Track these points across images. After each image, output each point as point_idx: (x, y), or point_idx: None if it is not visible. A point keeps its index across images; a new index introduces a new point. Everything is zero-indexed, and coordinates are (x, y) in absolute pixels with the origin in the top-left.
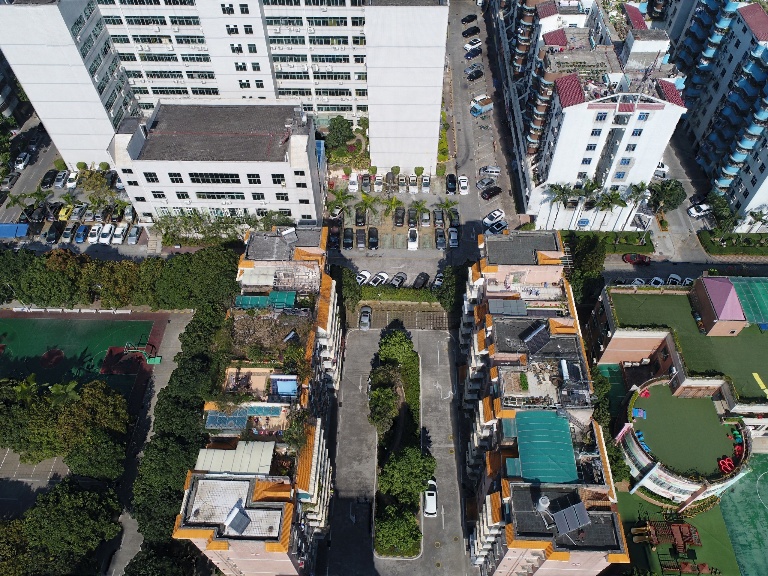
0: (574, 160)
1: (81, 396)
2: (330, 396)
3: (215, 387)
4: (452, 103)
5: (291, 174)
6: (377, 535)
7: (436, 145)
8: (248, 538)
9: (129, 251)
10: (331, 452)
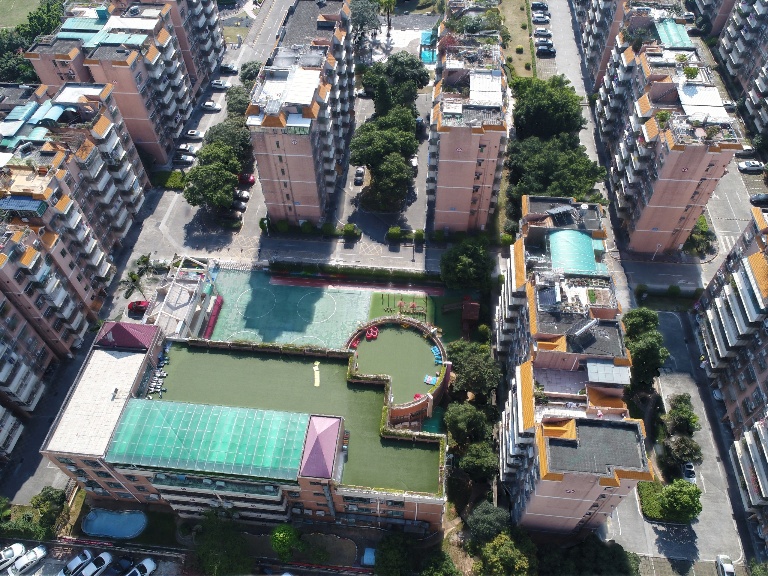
0: None
1: None
2: None
3: None
4: None
5: None
6: None
7: None
8: None
9: None
10: (711, 411)
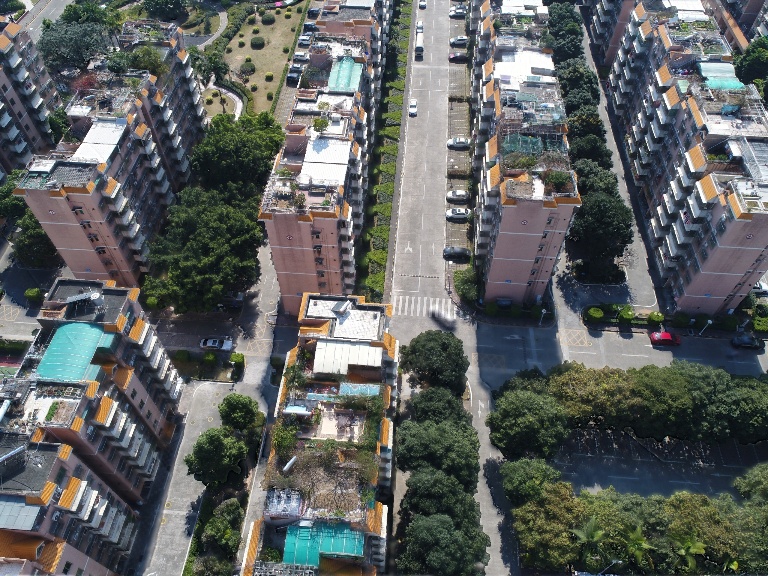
0: None
1: (572, 538)
2: None
3: None
4: None
5: None
6: (257, 409)
7: None
8: (333, 300)
9: None
10: None
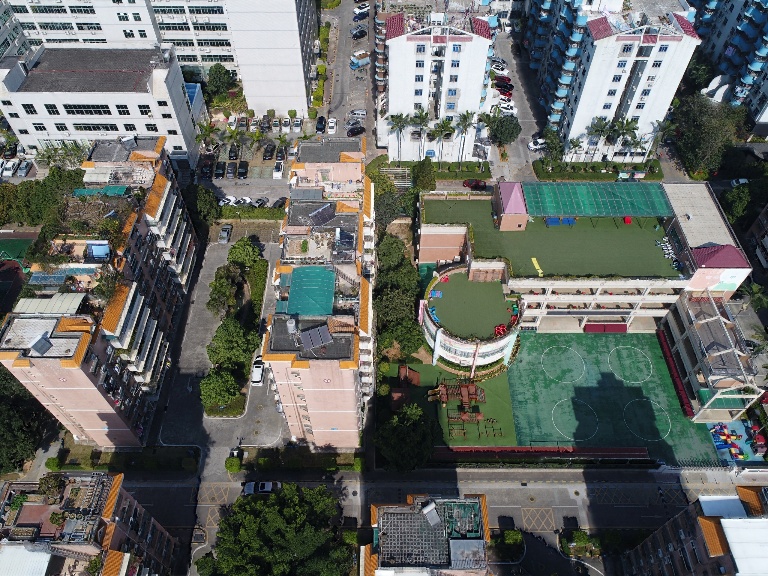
0: (407, 91)
1: None
2: (180, 292)
3: (40, 253)
4: (334, 58)
5: (155, 105)
6: None
7: (303, 88)
8: None
9: (18, 183)
10: (178, 339)
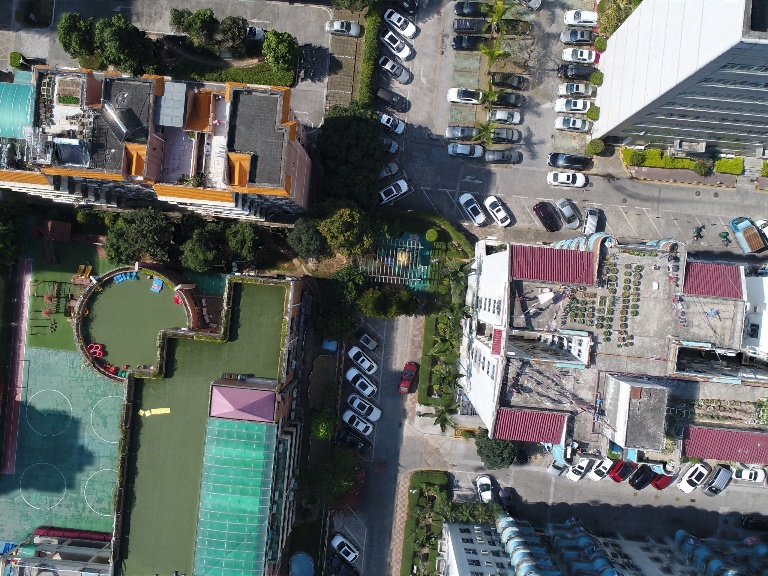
0: None
1: None
2: None
3: None
4: None
5: None
6: None
7: (613, 125)
8: None
9: None
10: None
